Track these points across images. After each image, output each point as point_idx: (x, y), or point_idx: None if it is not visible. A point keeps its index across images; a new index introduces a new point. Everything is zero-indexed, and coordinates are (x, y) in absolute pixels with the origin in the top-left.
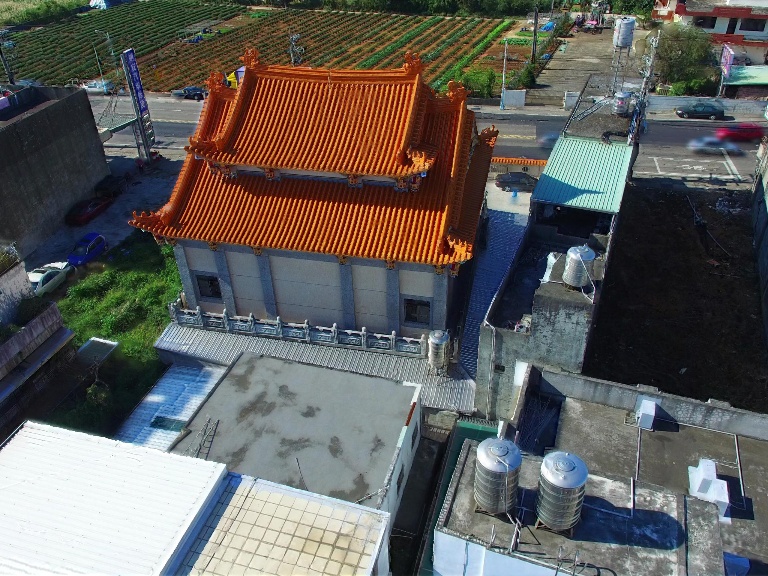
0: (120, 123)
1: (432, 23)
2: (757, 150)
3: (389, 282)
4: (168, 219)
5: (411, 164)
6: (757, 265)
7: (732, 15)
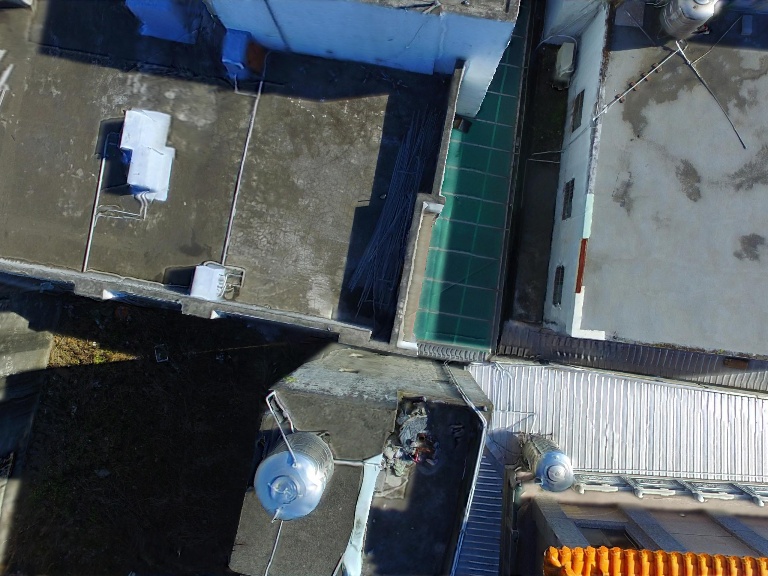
0: None
1: None
2: None
3: None
4: None
5: None
6: None
7: None
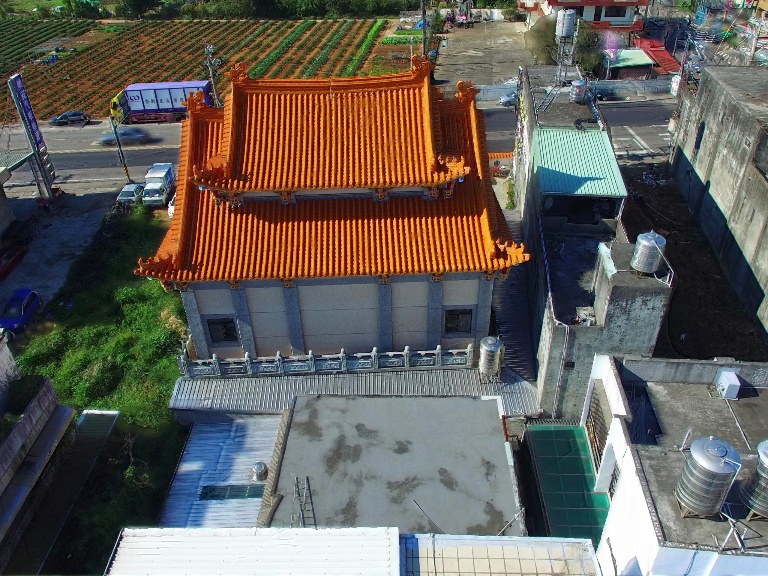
0: (16, 160)
1: (306, 27)
2: (668, 125)
3: (432, 295)
4: (179, 262)
5: (447, 170)
6: (701, 229)
7: (598, 4)
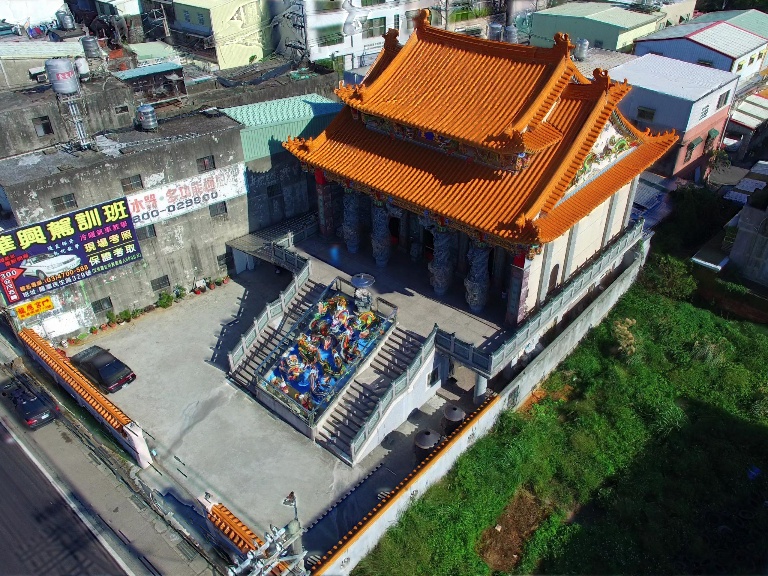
0: None
1: None
2: None
3: None
4: None
5: None
6: None
7: None
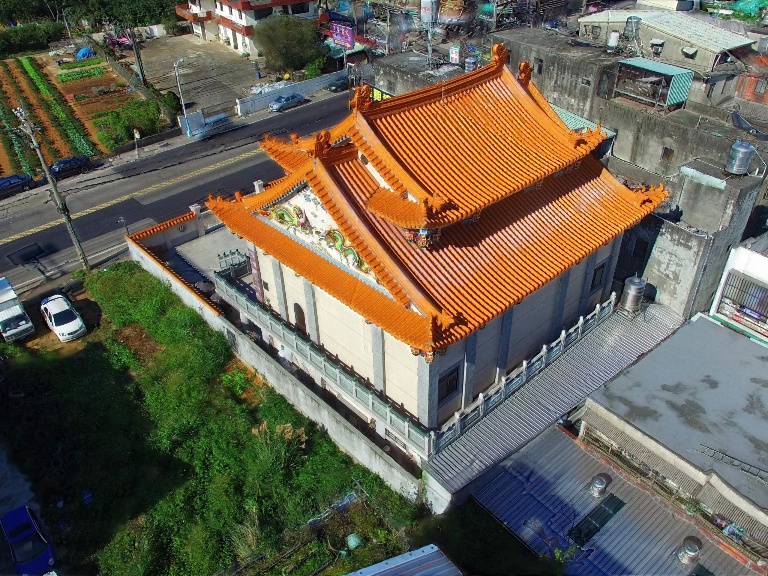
0: None
1: None
2: None
3: (592, 261)
4: None
5: (584, 142)
6: None
7: None
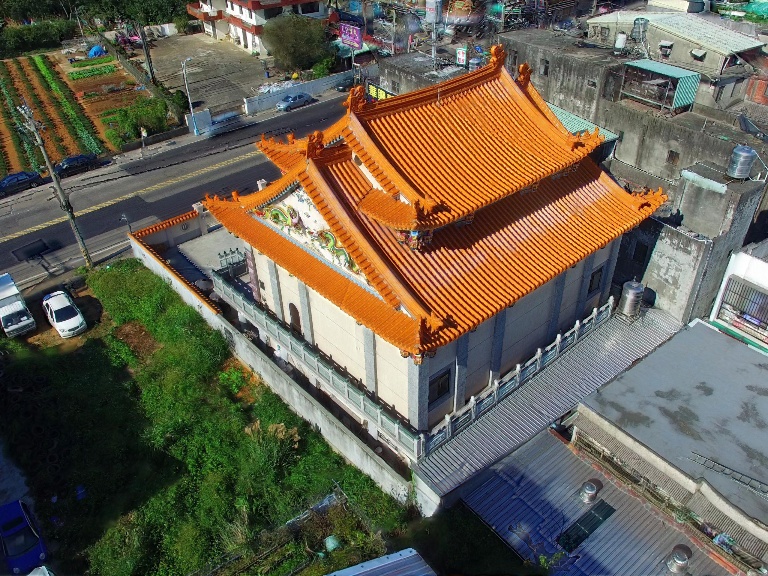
0: None
1: None
2: None
3: (589, 264)
4: None
5: (582, 144)
6: None
7: (295, 2)
